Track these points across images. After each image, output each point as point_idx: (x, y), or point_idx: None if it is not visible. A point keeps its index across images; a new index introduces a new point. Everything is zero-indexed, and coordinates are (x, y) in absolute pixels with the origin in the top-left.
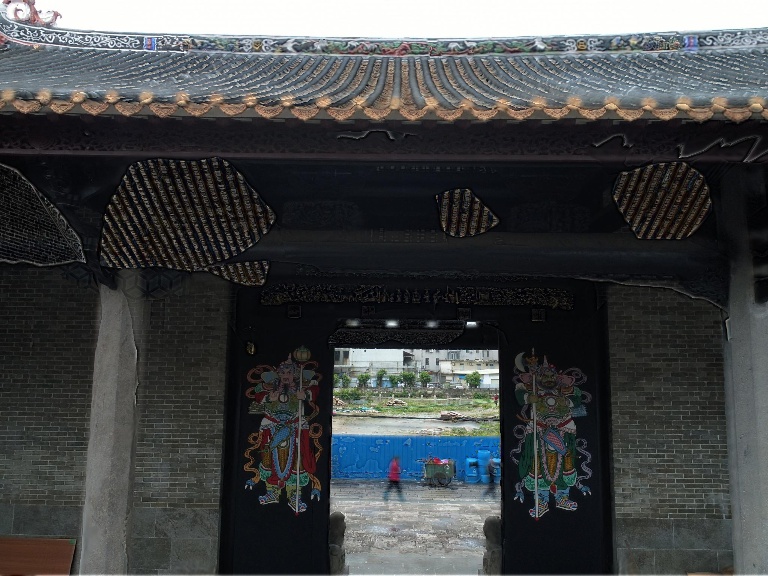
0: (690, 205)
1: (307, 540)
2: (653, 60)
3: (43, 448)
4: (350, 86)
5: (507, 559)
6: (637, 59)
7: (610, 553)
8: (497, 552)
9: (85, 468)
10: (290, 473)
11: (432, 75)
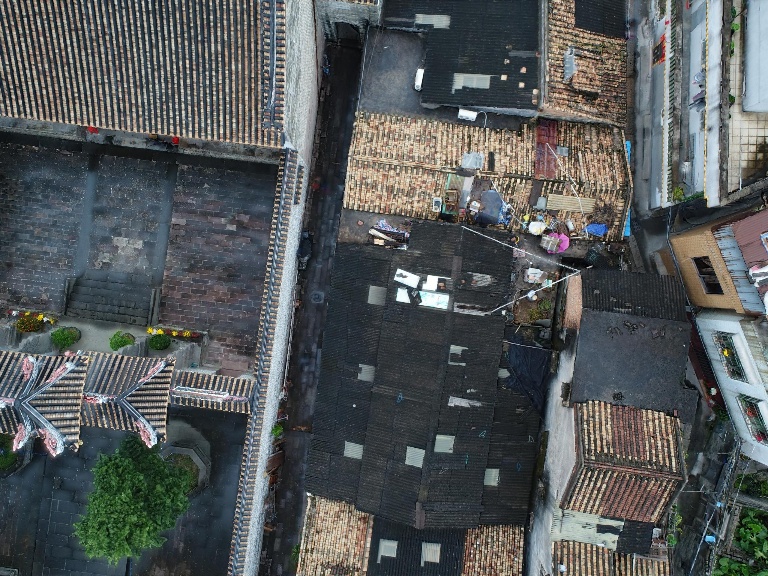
0: None
1: None
2: None
3: None
4: None
5: None
6: None
7: None
8: None
9: None
10: None
11: None
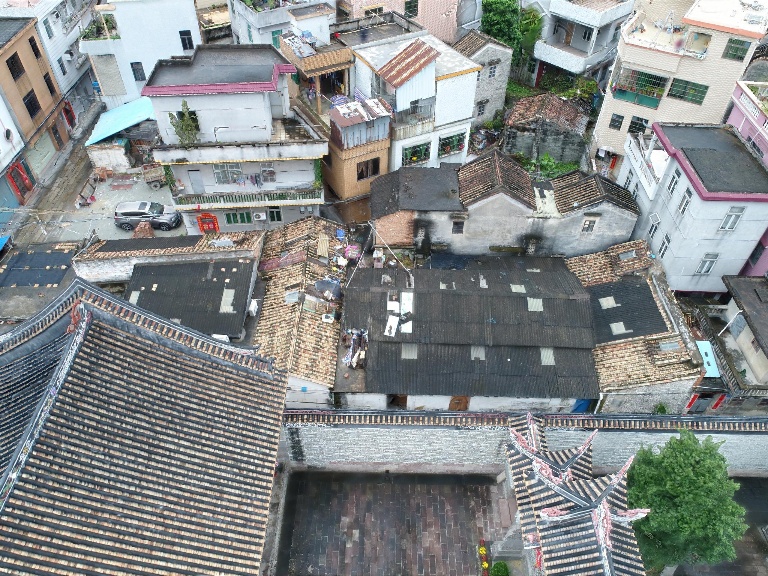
0: (8, 395)
1: None
2: (59, 425)
3: None
4: None
5: None
6: (52, 431)
7: None
8: None
9: None
10: None
11: (41, 569)
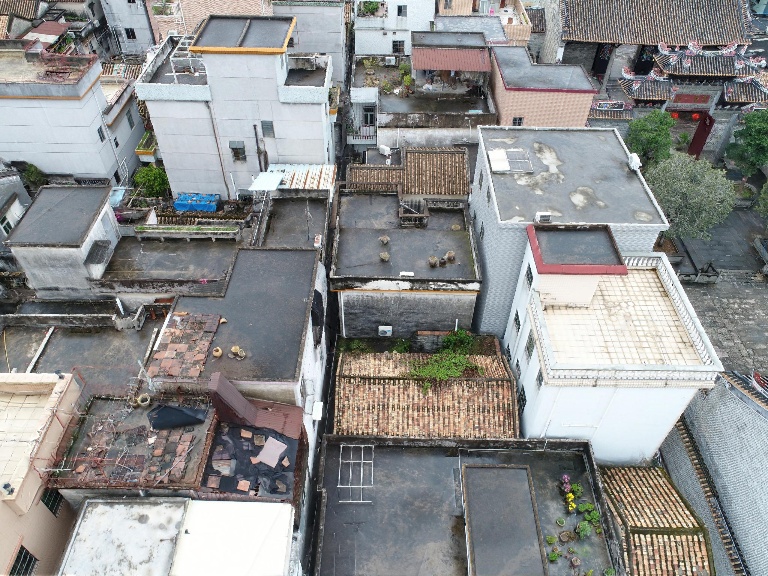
0: None
1: (606, 64)
2: None
3: (568, 50)
4: (641, 6)
5: (636, 67)
6: None
7: (653, 66)
8: (634, 65)
9: (574, 53)
10: (607, 54)
11: None
